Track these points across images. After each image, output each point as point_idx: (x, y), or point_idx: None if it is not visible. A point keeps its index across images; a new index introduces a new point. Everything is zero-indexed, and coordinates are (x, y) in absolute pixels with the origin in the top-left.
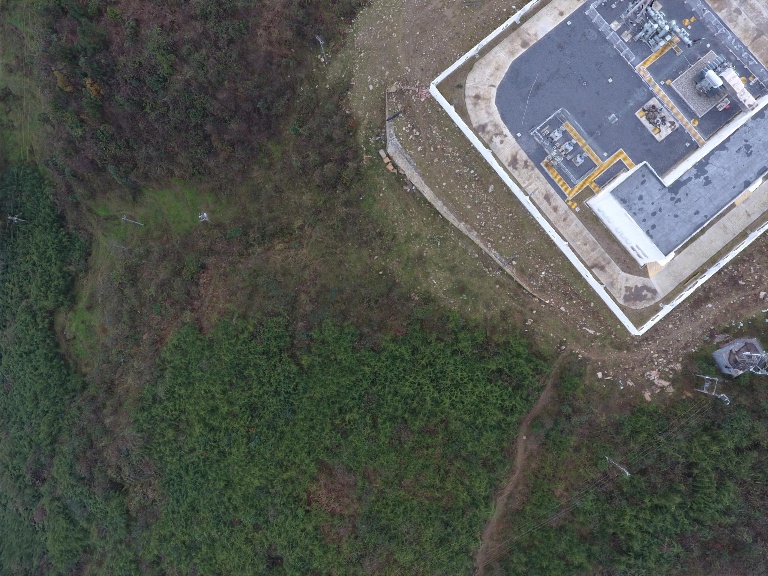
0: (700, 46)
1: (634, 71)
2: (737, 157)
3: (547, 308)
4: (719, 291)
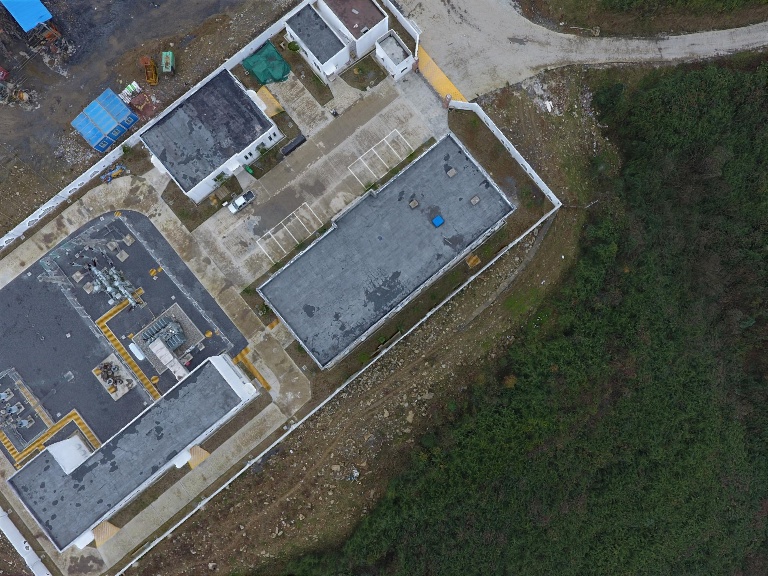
0: (165, 298)
1: (94, 325)
2: (147, 440)
3: (13, 568)
4: (170, 560)
